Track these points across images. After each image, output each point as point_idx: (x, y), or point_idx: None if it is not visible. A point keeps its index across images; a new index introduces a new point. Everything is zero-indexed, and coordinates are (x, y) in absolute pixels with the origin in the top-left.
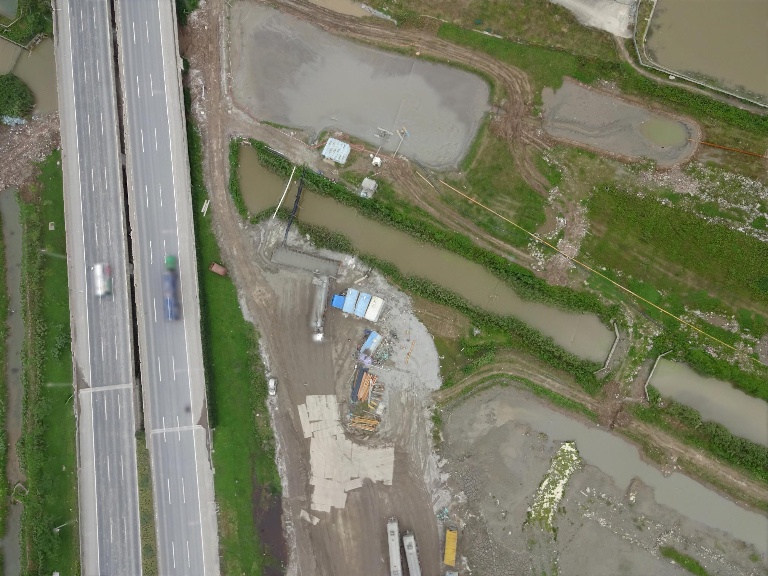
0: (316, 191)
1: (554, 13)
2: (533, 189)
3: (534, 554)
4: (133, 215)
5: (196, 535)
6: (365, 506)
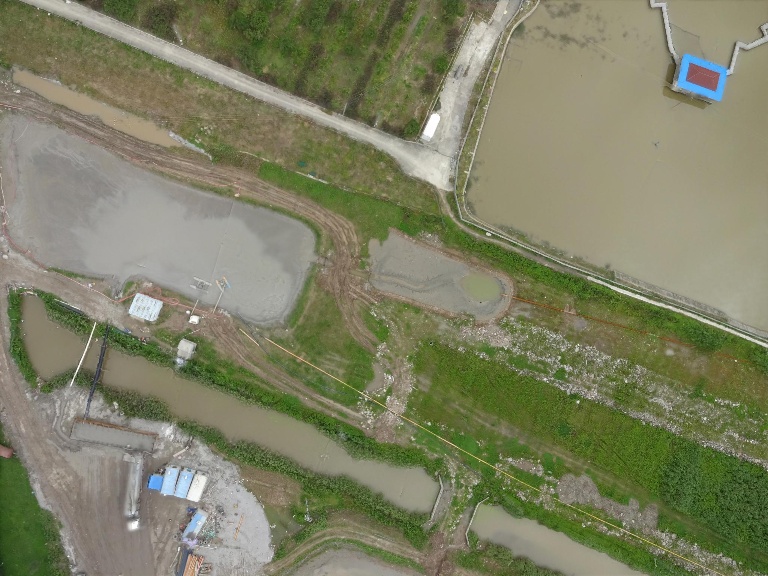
0: (123, 351)
1: (379, 160)
2: (361, 346)
3: None
4: None
5: None
6: None
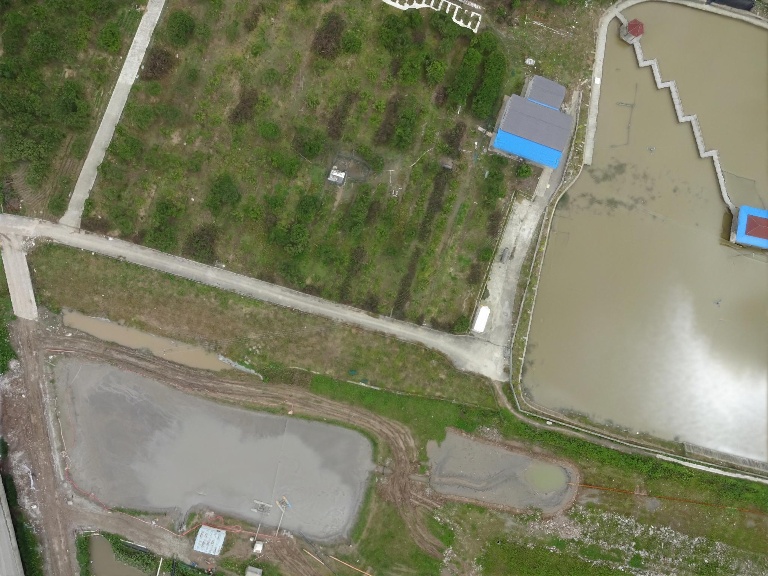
0: None
1: (431, 359)
2: (428, 554)
3: None
4: None
5: None
6: None
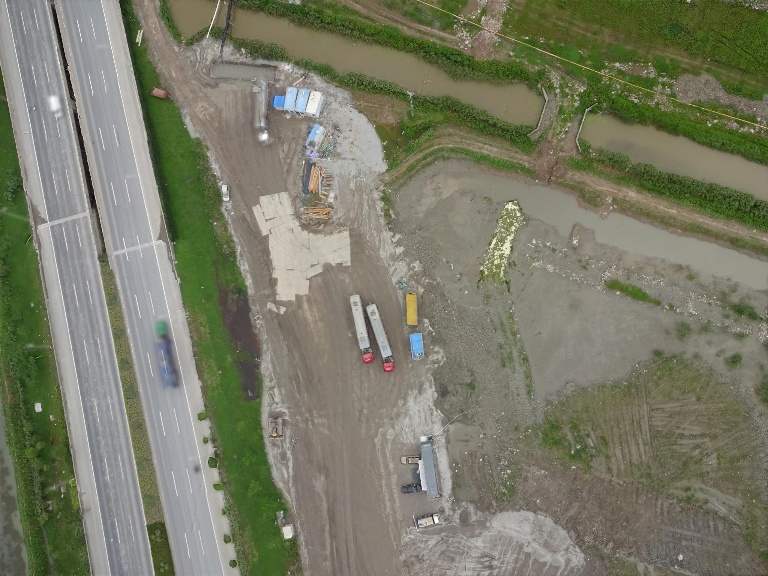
0: (246, 6)
1: None
2: None
3: (491, 307)
4: (68, 51)
5: (169, 343)
6: (328, 289)
